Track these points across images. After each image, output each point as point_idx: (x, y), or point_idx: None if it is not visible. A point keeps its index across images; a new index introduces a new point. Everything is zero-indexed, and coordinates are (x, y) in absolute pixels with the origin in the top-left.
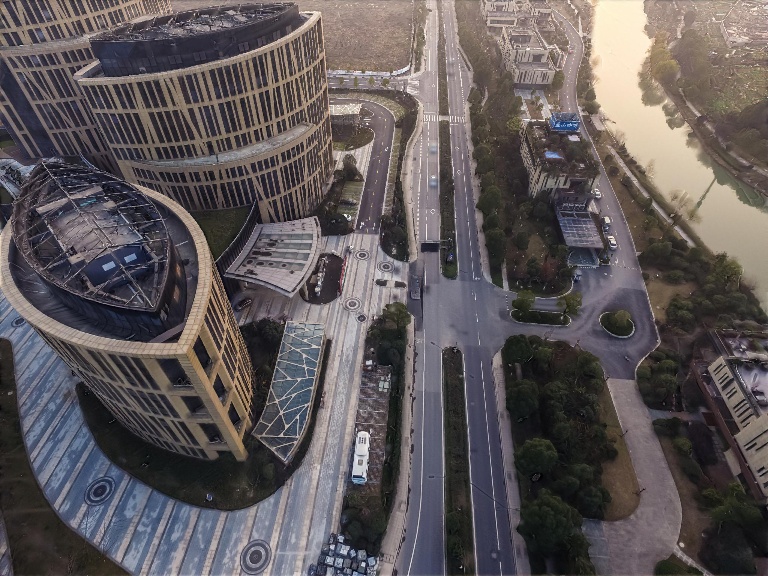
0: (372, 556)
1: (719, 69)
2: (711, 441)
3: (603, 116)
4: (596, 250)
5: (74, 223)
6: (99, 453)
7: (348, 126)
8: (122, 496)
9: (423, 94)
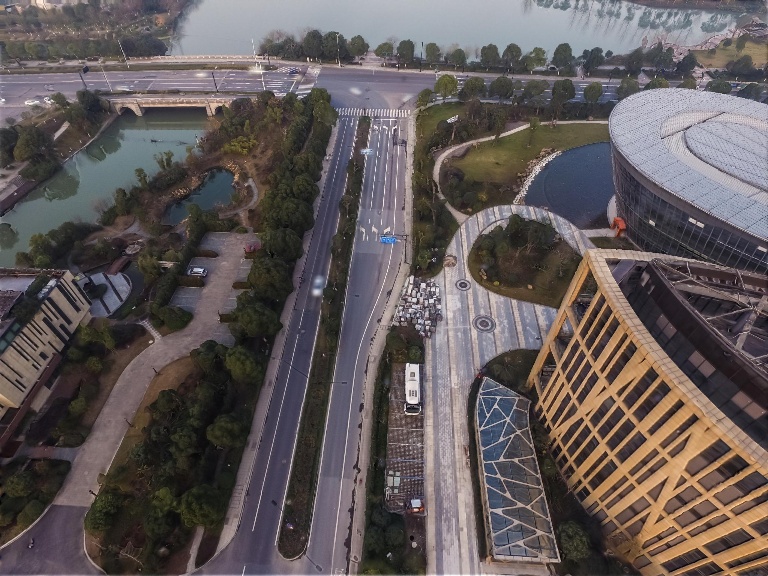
0: None
1: None
2: None
3: None
4: None
5: None
6: None
7: None
8: None
9: None
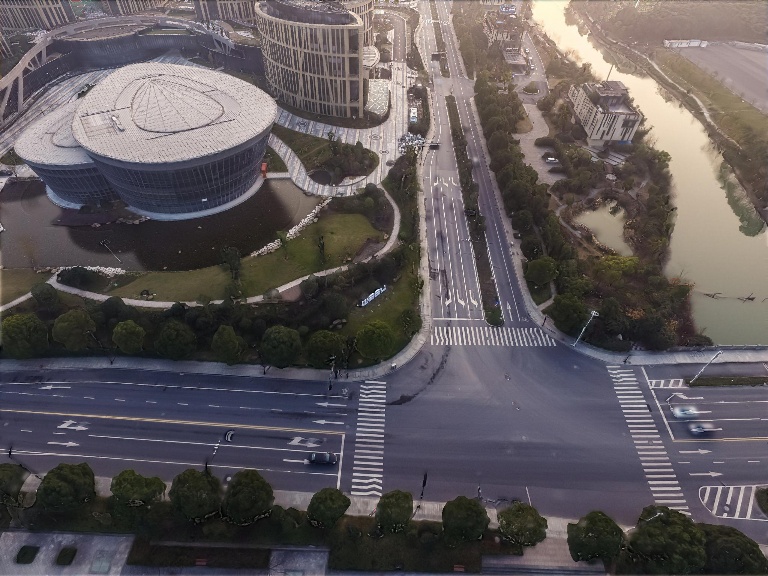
0: (423, 137)
1: (614, 2)
2: (566, 117)
3: (536, 23)
4: (523, 68)
5: (295, 2)
6: (296, 116)
7: (377, 22)
8: (313, 125)
9: (421, 11)
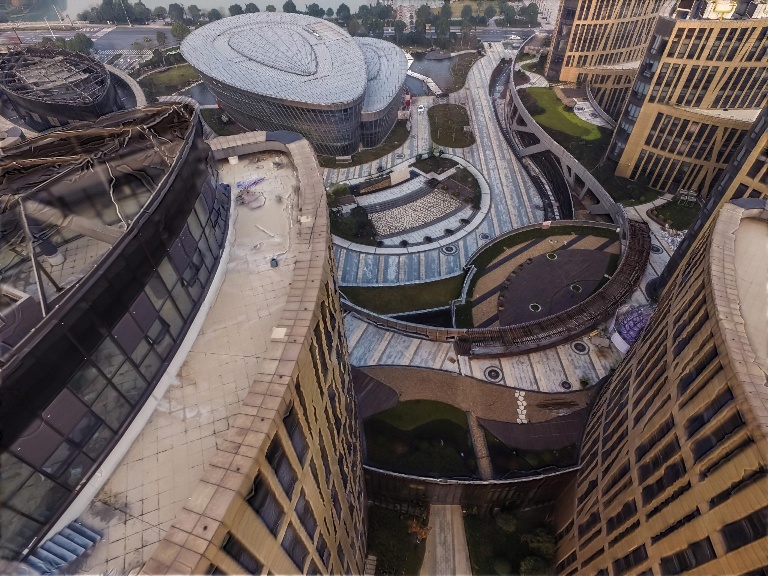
0: None
1: None
2: None
3: None
4: None
5: None
6: None
7: None
8: None
9: None
